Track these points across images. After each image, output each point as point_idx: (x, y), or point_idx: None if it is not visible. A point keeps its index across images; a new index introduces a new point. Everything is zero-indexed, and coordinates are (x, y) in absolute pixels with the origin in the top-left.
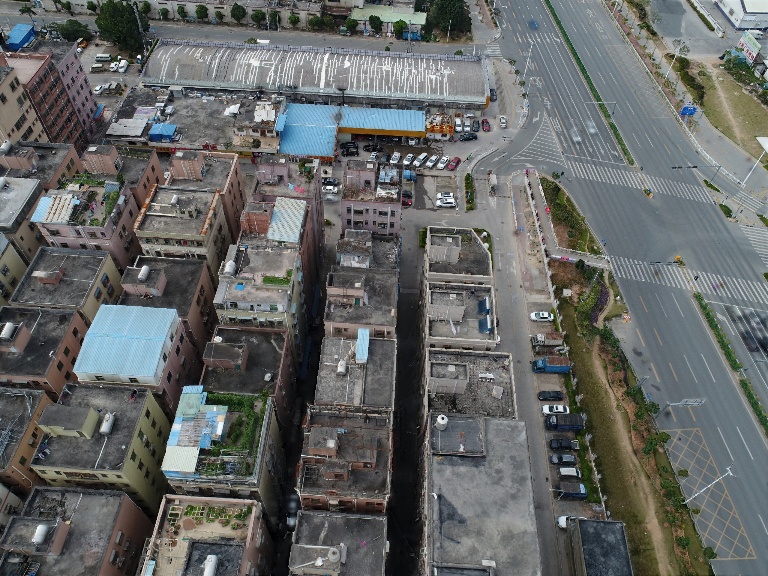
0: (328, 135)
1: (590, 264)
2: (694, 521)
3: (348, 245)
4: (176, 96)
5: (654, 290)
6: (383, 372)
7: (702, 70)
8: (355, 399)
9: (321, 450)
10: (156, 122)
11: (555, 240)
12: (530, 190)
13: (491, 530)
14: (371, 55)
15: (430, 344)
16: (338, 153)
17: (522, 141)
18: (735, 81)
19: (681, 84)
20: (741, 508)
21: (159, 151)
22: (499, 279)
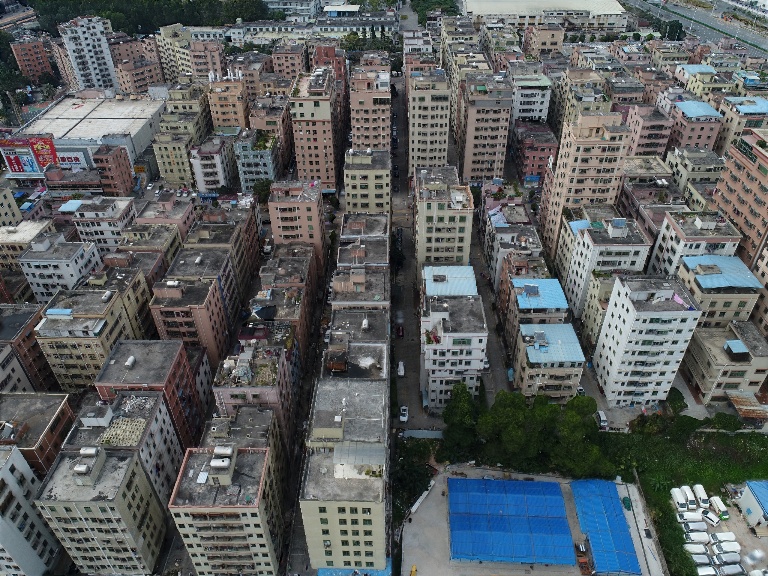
0: None
1: None
2: None
3: None
4: None
5: None
6: None
7: None
8: None
9: None
10: None
11: None
12: None
13: None
14: None
15: None
16: None
17: None
18: None
19: None
20: None
21: None
22: None
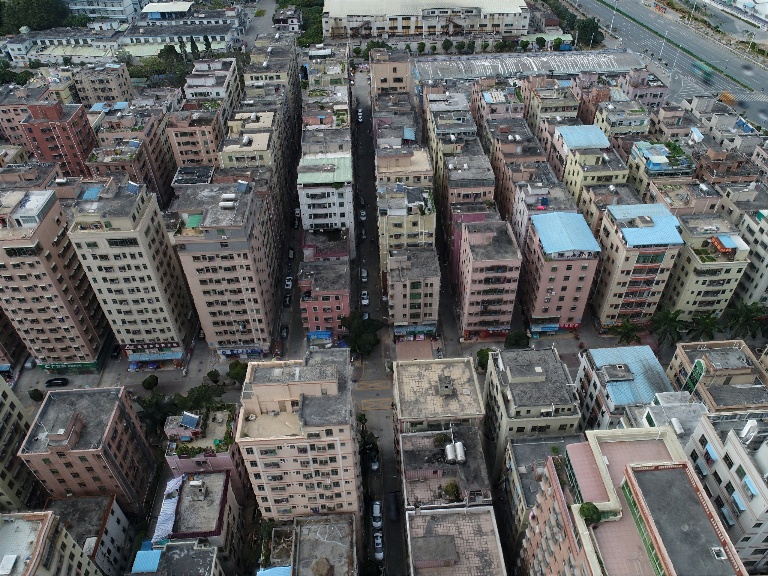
0: None
1: None
2: None
3: None
4: None
5: None
6: (713, 144)
7: (766, 46)
8: None
9: (720, 154)
10: None
11: None
12: None
13: None
14: (553, 55)
15: (721, 141)
16: None
17: (676, 88)
18: None
19: None
20: None
21: None
22: None
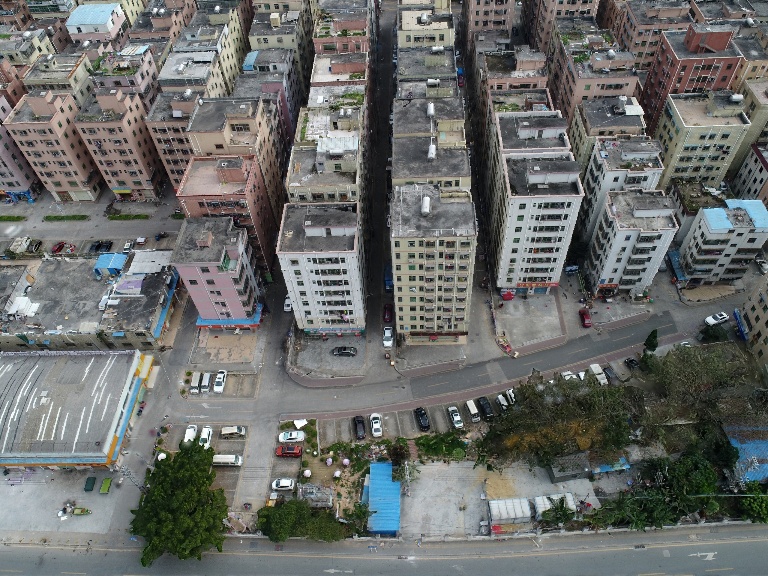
0: None
1: None
2: None
3: None
4: None
5: None
6: None
7: None
8: None
9: None
10: None
11: None
12: None
13: None
14: None
15: None
16: None
17: None
18: None
19: None
20: None
21: None
22: None
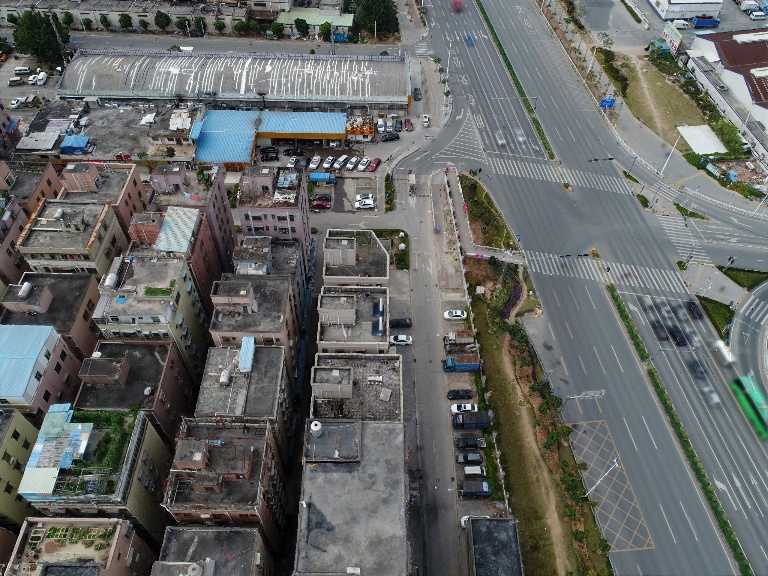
0: (246, 141)
1: (505, 260)
2: (594, 514)
3: (245, 252)
4: (92, 107)
5: (568, 283)
6: (267, 380)
7: (627, 62)
8: (237, 409)
9: (188, 464)
10: (69, 134)
11: (471, 237)
12: (448, 188)
13: (359, 536)
14: (294, 58)
15: (322, 349)
16: (258, 159)
17: (444, 139)
18: (659, 72)
19: (606, 77)
20: (642, 498)
21: None
22: (415, 279)
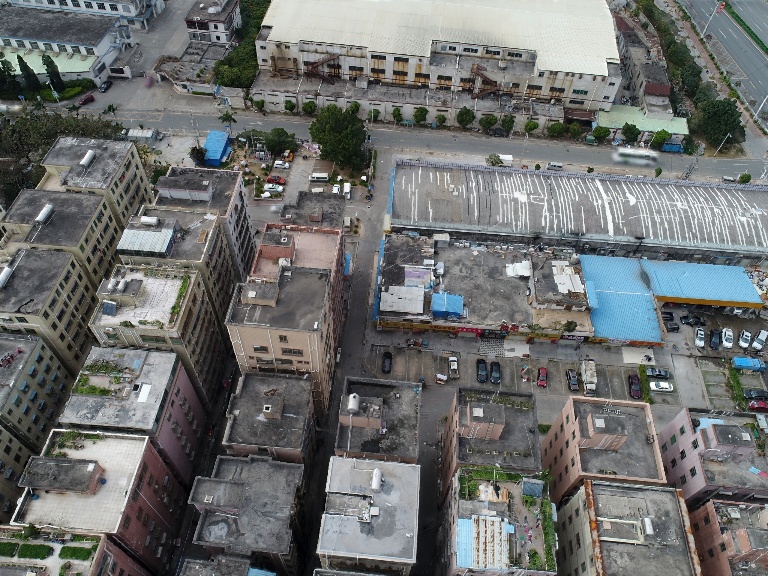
0: (645, 307)
1: None
2: None
3: None
4: (440, 246)
5: None
6: None
7: None
8: None
9: None
10: (433, 289)
11: None
12: None
13: None
14: (649, 182)
15: None
16: None
17: None
18: None
19: None
20: None
21: (441, 329)
22: None
